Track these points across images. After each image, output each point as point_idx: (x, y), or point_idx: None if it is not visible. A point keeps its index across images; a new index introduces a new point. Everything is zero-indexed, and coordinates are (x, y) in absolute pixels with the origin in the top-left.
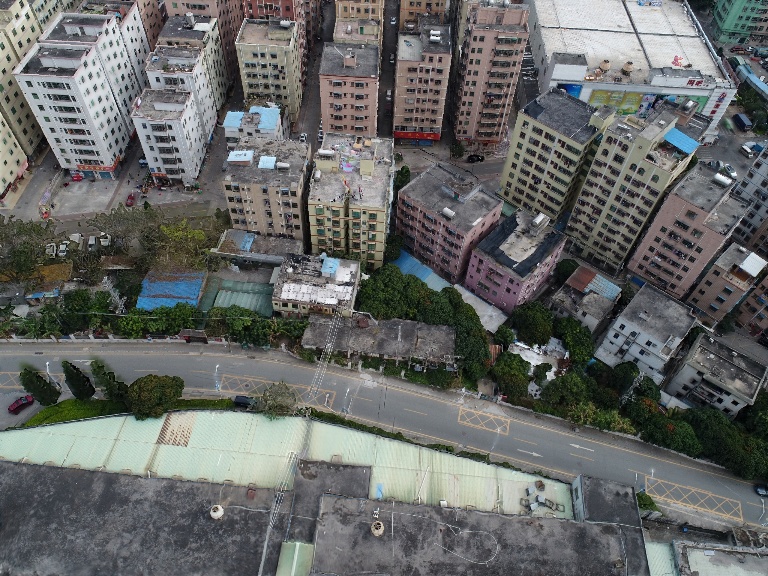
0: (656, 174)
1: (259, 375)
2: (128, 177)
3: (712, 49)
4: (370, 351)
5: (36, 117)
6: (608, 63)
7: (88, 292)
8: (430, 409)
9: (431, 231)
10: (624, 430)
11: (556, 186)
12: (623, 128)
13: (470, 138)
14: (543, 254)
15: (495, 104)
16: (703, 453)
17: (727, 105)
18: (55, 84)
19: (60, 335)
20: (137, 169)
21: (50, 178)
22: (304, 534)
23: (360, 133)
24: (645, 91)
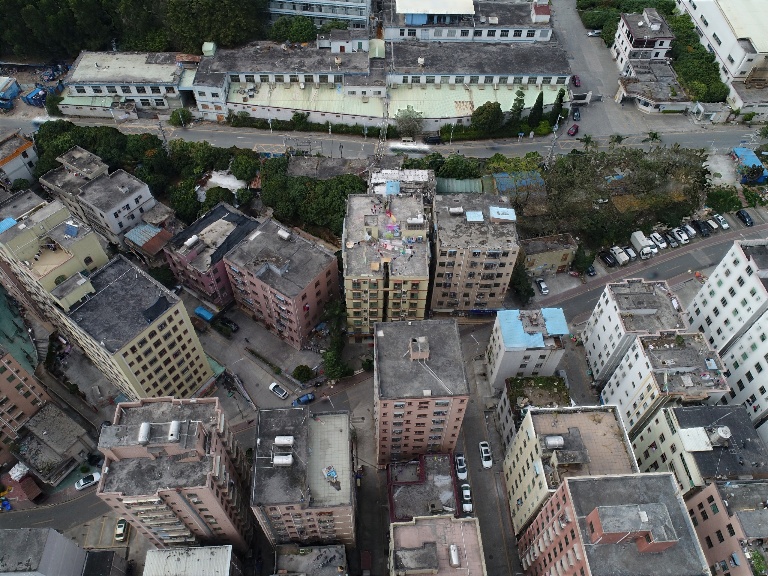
0: None
1: None
2: None
3: None
4: (352, 159)
5: None
6: None
7: None
8: None
9: None
10: None
11: None
12: None
13: None
14: (195, 228)
15: None
16: None
17: None
18: None
19: None
20: None
21: None
22: (375, 64)
23: None
24: None
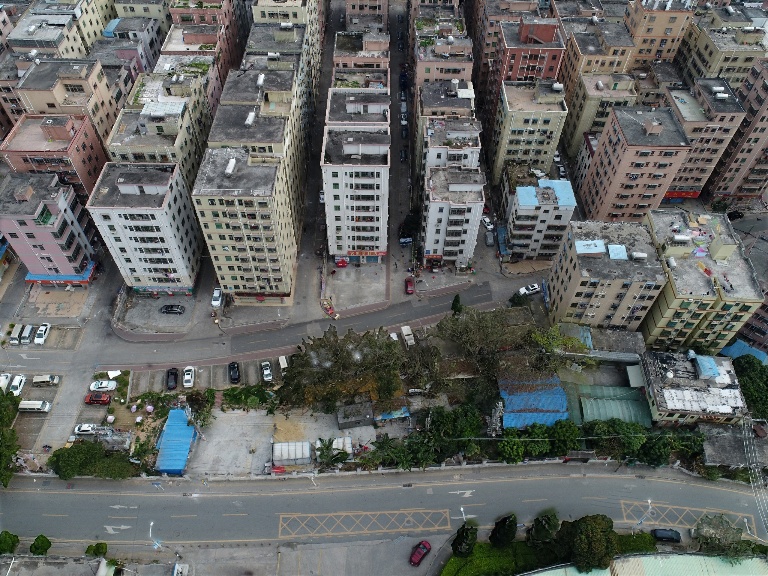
0: None
1: (659, 499)
2: (393, 259)
3: None
4: None
5: (326, 206)
6: None
7: (445, 410)
8: None
9: None
10: None
11: None
12: None
13: (729, 194)
14: None
15: None
16: None
17: None
18: (364, 173)
19: (431, 464)
20: (398, 249)
21: (318, 266)
22: None
23: (645, 201)
24: None
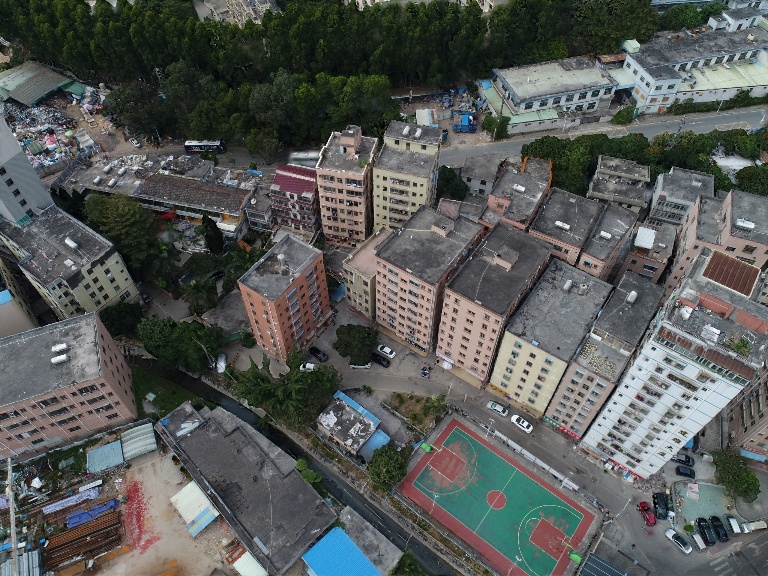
0: None
1: None
2: None
3: None
4: None
5: None
6: None
7: None
8: None
9: None
10: None
11: None
12: None
13: None
14: None
15: None
16: None
17: None
18: None
19: None
20: None
21: None
22: None
23: None
24: None
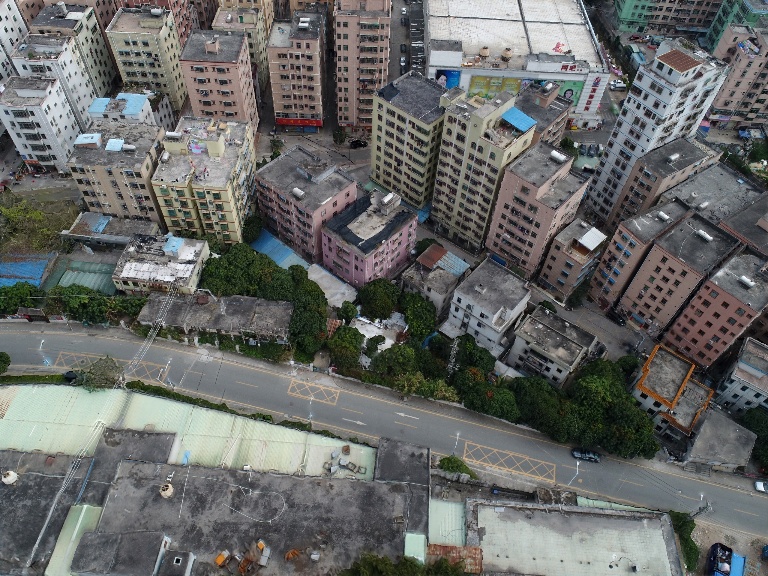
0: (492, 151)
1: (96, 352)
2: (3, 165)
3: (594, 36)
4: (205, 326)
5: None
6: (487, 49)
7: None
8: (262, 381)
9: (286, 212)
10: (447, 398)
11: (415, 167)
12: (461, 107)
13: (352, 124)
14: (391, 232)
15: (370, 90)
16: (521, 418)
17: (603, 89)
18: None
19: None
20: (13, 157)
21: None
22: (96, 498)
23: (231, 119)
24: (522, 76)
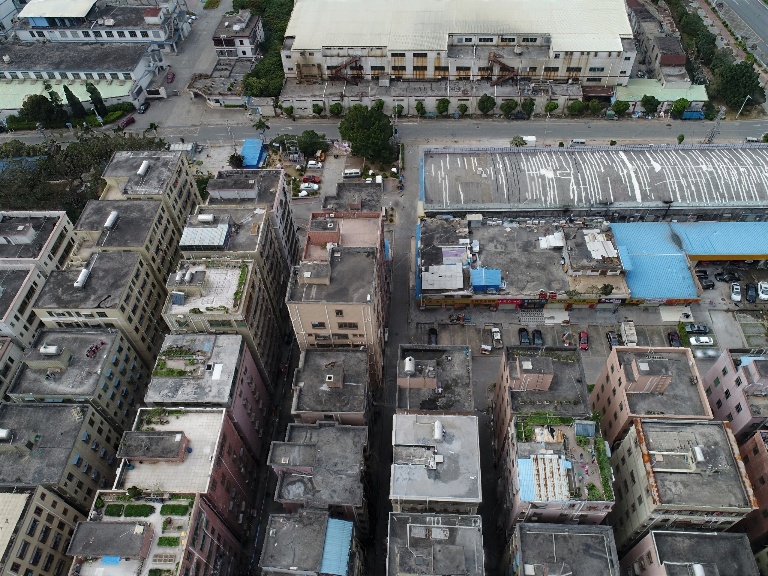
0: None
1: None
2: None
3: None
4: None
5: None
6: None
7: None
8: None
9: None
10: None
11: None
12: None
13: None
14: None
15: None
16: None
17: None
18: None
19: None
20: None
21: None
22: None
23: None
24: None
